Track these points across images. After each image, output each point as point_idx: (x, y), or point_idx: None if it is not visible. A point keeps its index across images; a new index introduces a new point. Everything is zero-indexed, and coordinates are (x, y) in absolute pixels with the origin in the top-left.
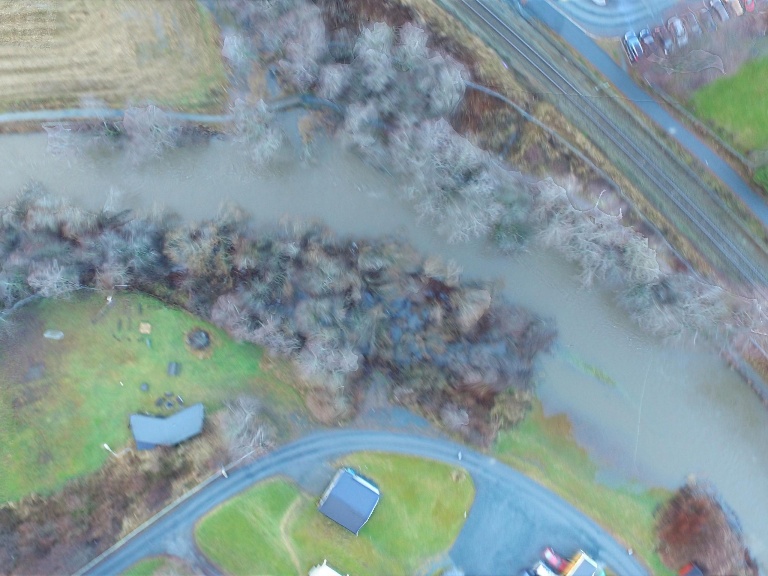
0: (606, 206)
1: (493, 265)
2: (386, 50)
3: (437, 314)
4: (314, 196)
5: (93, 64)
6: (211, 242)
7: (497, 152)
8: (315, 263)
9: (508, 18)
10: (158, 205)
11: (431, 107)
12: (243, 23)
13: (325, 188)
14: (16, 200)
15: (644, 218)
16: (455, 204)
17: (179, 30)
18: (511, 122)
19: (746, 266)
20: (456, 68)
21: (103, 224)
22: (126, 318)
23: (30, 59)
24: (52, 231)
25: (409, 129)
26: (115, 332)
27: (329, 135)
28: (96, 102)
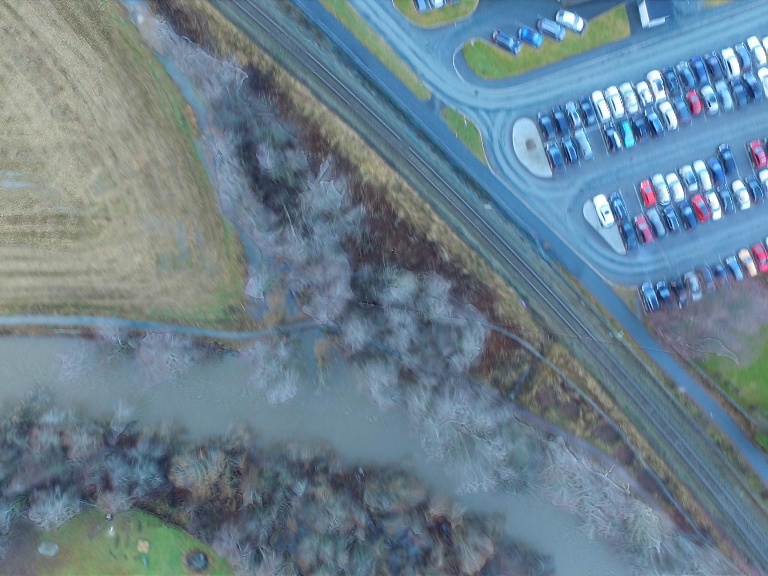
0: (611, 451)
1: (497, 500)
2: (410, 301)
3: (439, 558)
4: (325, 421)
5: (111, 272)
6: (218, 469)
7: (509, 389)
8: (322, 502)
9: (530, 259)
10: (167, 424)
11: (451, 367)
12: (269, 257)
13: (336, 415)
14: (20, 405)
15: (648, 468)
16: (465, 448)
17: (202, 243)
18: (525, 361)
19: (742, 518)
20: (477, 320)
21: (108, 438)
22: (124, 535)
23: (47, 262)
24: (56, 451)
25: (428, 391)
26: (112, 548)
27: (344, 361)
28: (111, 311)
